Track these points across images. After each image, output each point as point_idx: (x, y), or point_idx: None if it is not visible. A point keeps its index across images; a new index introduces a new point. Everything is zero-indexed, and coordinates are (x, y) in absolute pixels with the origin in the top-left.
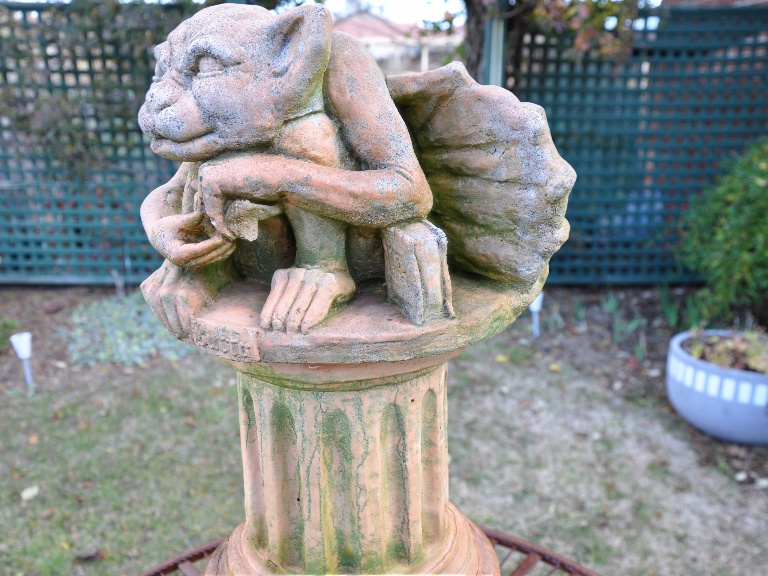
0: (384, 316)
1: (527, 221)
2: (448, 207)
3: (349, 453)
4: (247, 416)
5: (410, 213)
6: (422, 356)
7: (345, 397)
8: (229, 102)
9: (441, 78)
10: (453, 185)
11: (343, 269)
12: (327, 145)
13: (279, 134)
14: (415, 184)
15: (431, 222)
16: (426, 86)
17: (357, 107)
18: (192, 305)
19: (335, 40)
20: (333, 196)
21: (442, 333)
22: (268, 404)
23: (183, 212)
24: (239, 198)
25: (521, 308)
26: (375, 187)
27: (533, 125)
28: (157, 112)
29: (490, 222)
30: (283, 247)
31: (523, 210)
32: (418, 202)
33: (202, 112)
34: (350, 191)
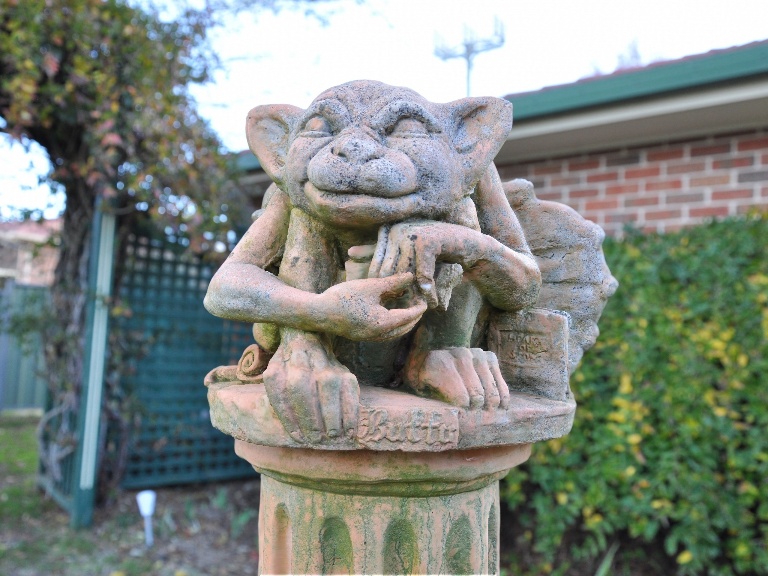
0: (527, 397)
1: (579, 316)
2: None
3: (467, 569)
4: (322, 557)
5: None
6: None
7: (469, 499)
8: (444, 164)
9: (516, 190)
10: None
11: None
12: None
13: None
14: None
15: None
16: None
17: (498, 196)
18: (358, 391)
19: None
20: (516, 269)
21: None
22: (381, 525)
23: (305, 288)
24: (448, 262)
25: None
26: None
27: (598, 234)
28: (362, 162)
29: None
30: None
31: (578, 306)
32: None
33: (417, 169)
34: (526, 266)
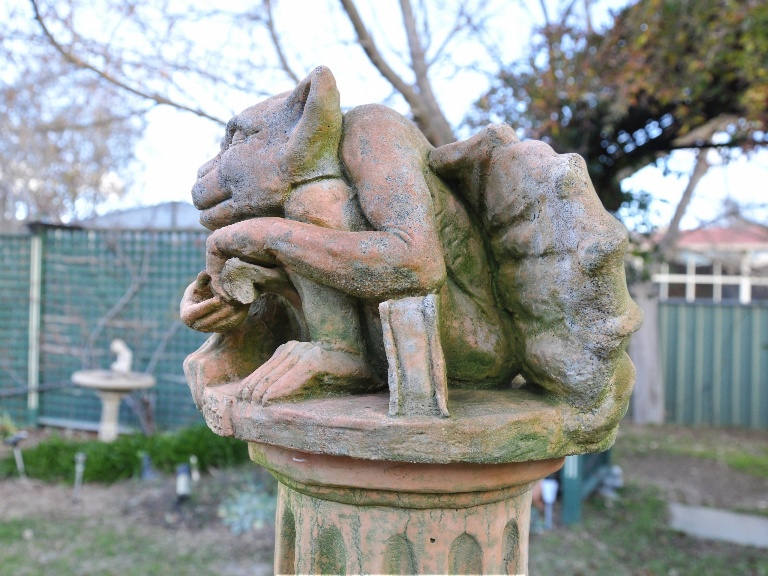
0: None
1: (569, 303)
2: (515, 301)
3: None
4: None
5: (407, 282)
6: (395, 459)
7: (342, 511)
8: (238, 165)
9: (478, 140)
10: (515, 272)
11: (353, 352)
12: (334, 209)
13: (288, 198)
14: (414, 248)
15: (507, 324)
16: (465, 152)
17: (366, 169)
18: (208, 374)
19: (361, 109)
20: (311, 254)
21: (421, 432)
22: (281, 508)
23: None
24: None
25: (583, 434)
26: (357, 245)
27: (555, 172)
28: None
29: (541, 312)
30: None
31: (562, 288)
32: (417, 269)
33: (221, 177)
34: (328, 248)
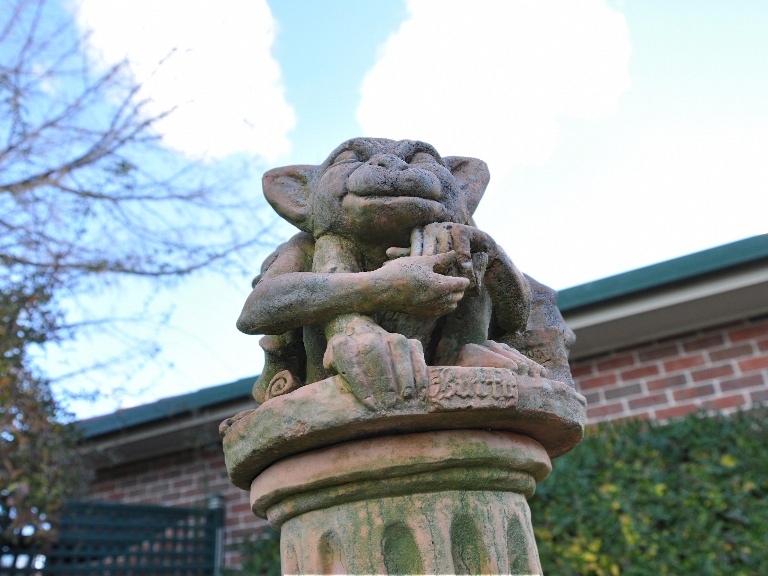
0: None
1: None
2: None
3: None
4: (387, 572)
5: None
6: None
7: (515, 500)
8: (457, 183)
9: None
10: None
11: None
12: None
13: None
14: None
15: None
16: None
17: None
18: None
19: None
20: (519, 277)
21: None
22: (446, 521)
23: None
24: (476, 252)
25: None
26: None
27: (552, 290)
28: (399, 169)
29: None
30: (424, 347)
31: None
32: None
33: (440, 181)
34: None
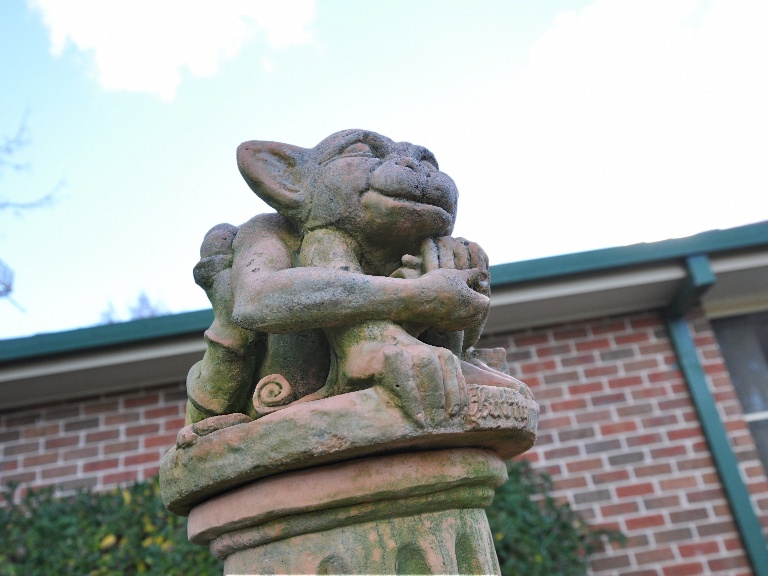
0: None
1: None
2: None
3: None
4: None
5: None
6: None
7: None
8: None
9: None
10: None
11: None
12: None
13: None
14: None
15: None
16: None
17: None
18: None
19: None
20: None
21: None
22: (452, 541)
23: None
24: None
25: None
26: None
27: None
28: None
29: None
30: None
31: None
32: None
33: None
34: None
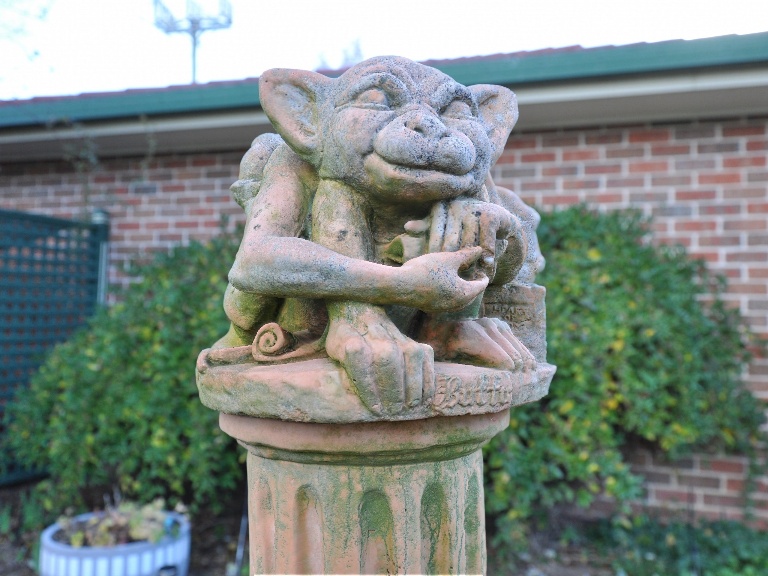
0: None
1: None
2: None
3: (475, 521)
4: (361, 530)
5: None
6: None
7: (476, 457)
8: None
9: None
10: None
11: None
12: None
13: None
14: None
15: None
16: None
17: None
18: None
19: None
20: None
21: None
22: (419, 490)
23: None
24: (497, 237)
25: None
26: None
27: None
28: None
29: None
30: None
31: (517, 281)
32: None
33: (475, 149)
34: None
